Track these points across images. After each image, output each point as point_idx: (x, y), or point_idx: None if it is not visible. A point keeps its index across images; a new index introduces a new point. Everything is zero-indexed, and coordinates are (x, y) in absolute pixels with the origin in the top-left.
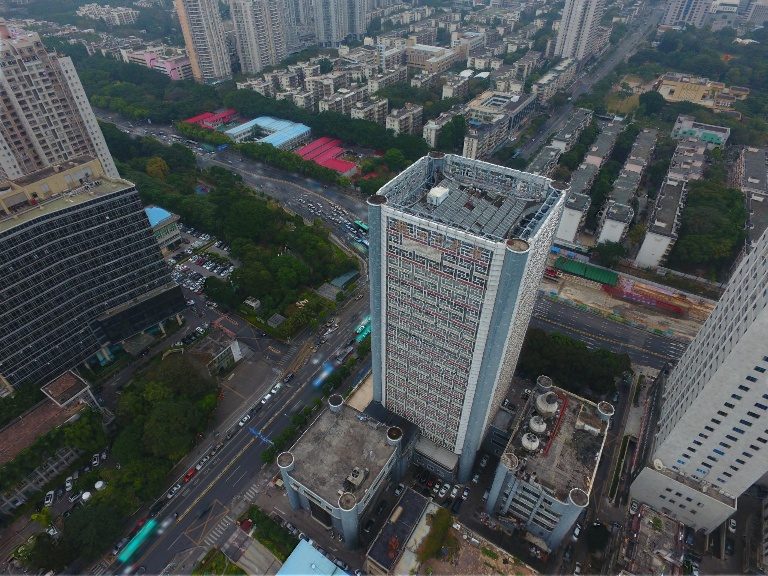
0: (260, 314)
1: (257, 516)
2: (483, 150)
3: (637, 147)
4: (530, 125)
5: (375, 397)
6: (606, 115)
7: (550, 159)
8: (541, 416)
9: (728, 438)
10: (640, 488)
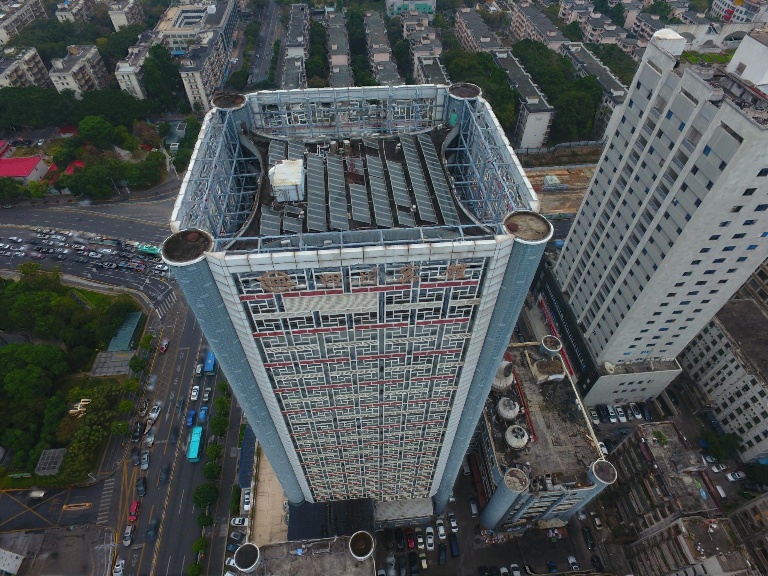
0: (13, 466)
1: None
2: (210, 84)
3: (372, 34)
4: (244, 39)
5: (294, 501)
6: (315, 8)
7: (299, 71)
8: (500, 393)
9: (674, 314)
10: (594, 396)
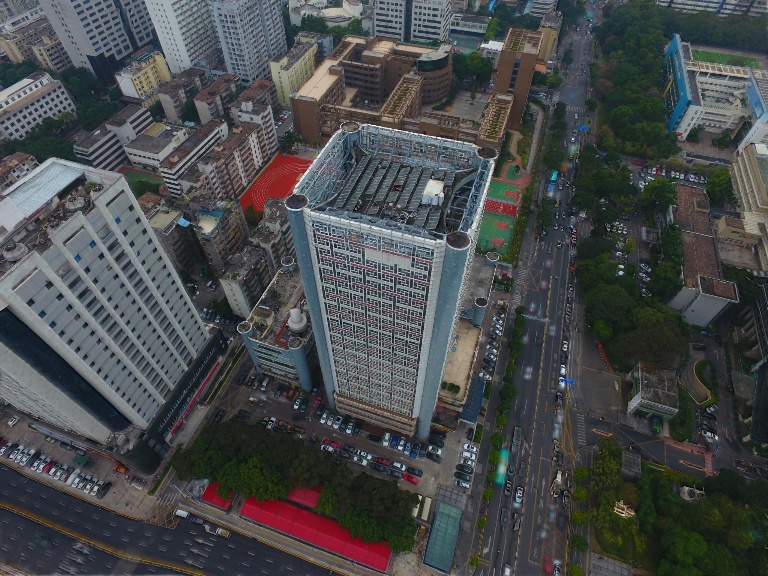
0: (665, 478)
1: (501, 280)
2: None
3: None
4: None
5: None
6: None
7: None
8: None
9: None
10: None
